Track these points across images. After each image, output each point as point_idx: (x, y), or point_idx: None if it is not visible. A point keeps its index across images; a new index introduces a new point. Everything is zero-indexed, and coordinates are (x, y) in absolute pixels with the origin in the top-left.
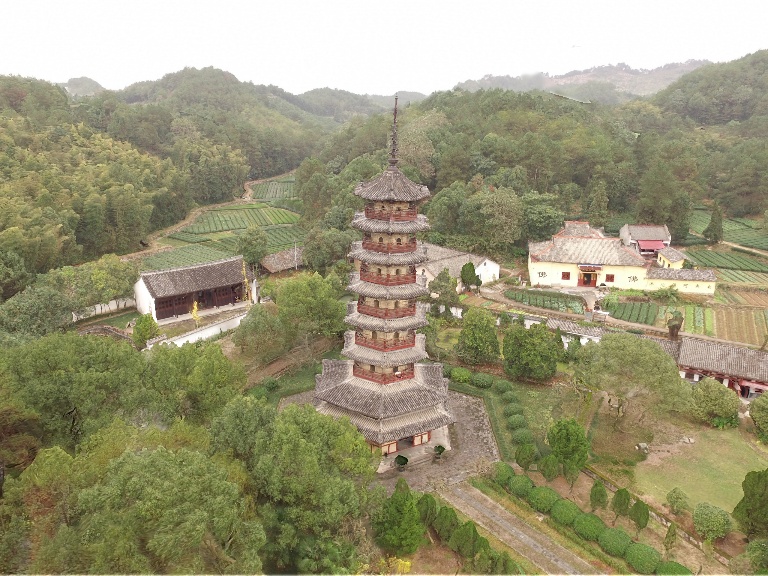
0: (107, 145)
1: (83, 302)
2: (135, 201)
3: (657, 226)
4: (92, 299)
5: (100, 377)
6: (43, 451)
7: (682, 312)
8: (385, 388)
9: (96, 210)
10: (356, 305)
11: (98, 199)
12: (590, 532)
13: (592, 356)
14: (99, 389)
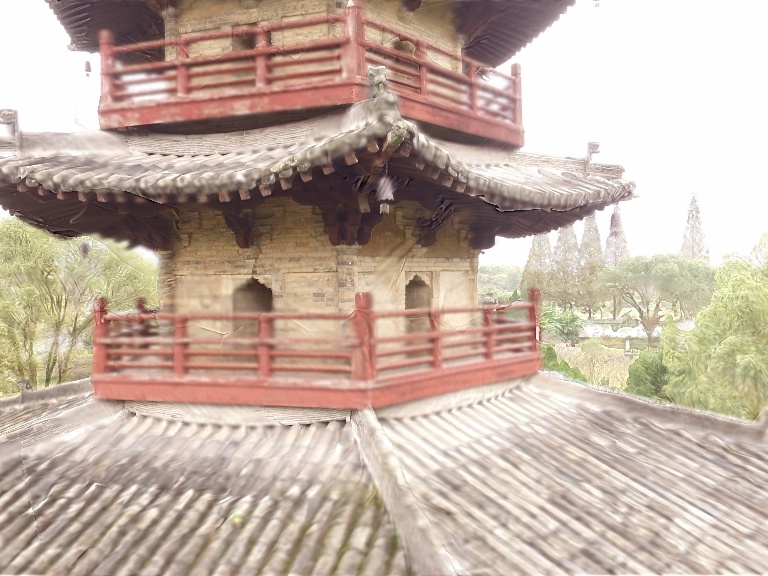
0: None
1: None
2: None
3: None
4: None
5: None
6: None
7: None
8: None
9: None
10: None
11: None
12: None
13: (89, 244)
14: None
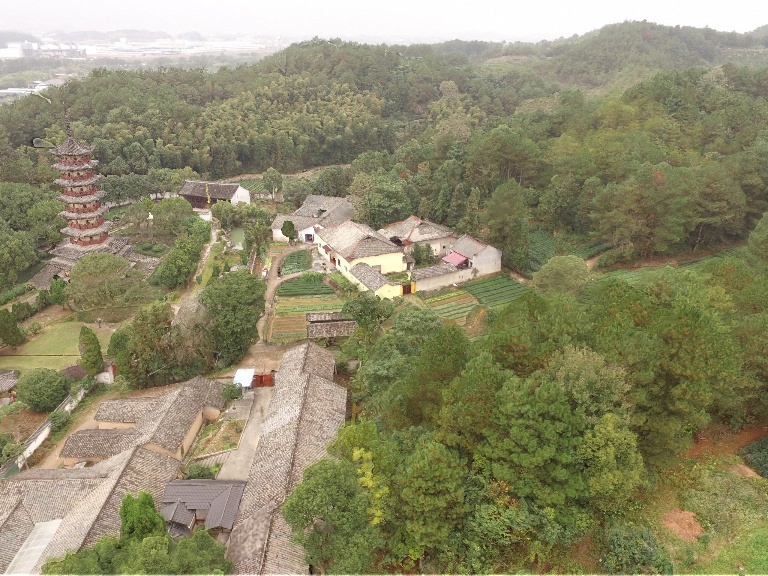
0: (346, 100)
1: (160, 187)
2: (289, 141)
3: (483, 244)
4: (171, 188)
5: (0, 199)
6: None
7: (328, 302)
8: (71, 245)
9: (259, 143)
10: None
11: (263, 136)
12: None
13: None
14: (1, 204)
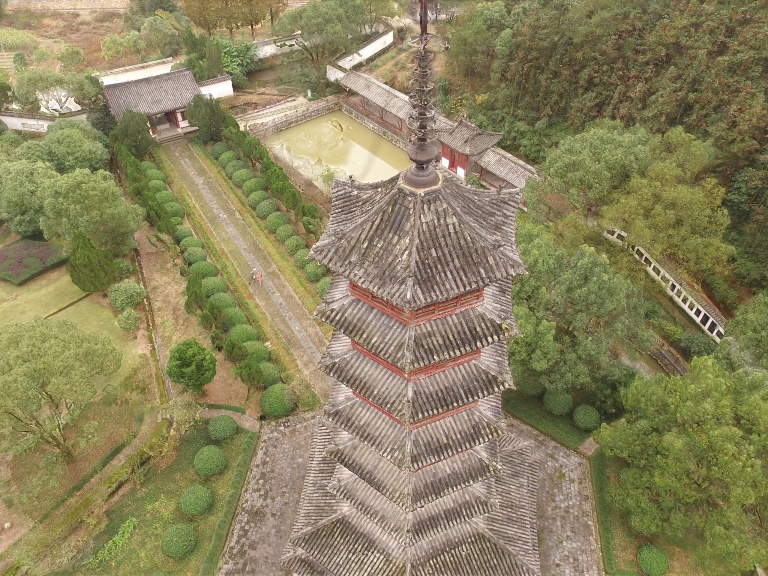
0: None
1: None
2: None
3: None
4: None
5: None
6: (697, 139)
7: None
8: None
9: None
10: (482, 450)
11: None
12: None
13: None
14: None
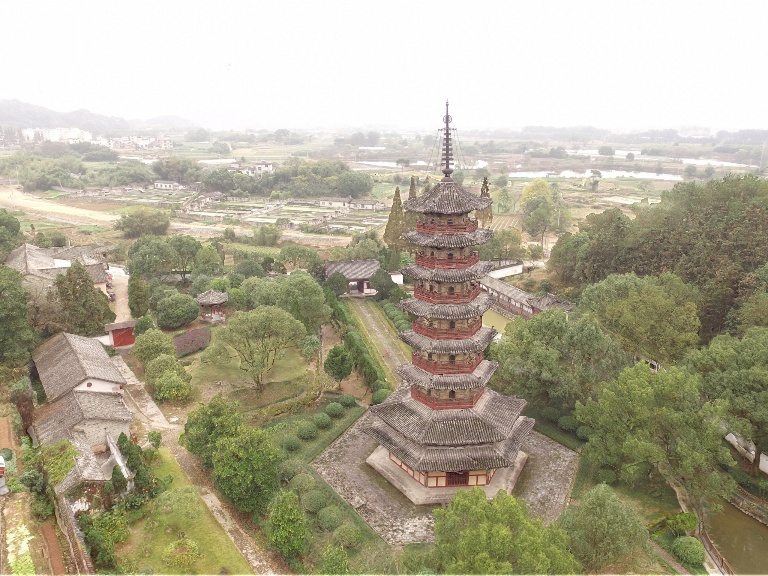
0: None
1: None
2: None
3: None
4: None
5: None
6: None
7: None
8: None
9: None
10: None
11: None
12: (373, 361)
13: None
14: None
